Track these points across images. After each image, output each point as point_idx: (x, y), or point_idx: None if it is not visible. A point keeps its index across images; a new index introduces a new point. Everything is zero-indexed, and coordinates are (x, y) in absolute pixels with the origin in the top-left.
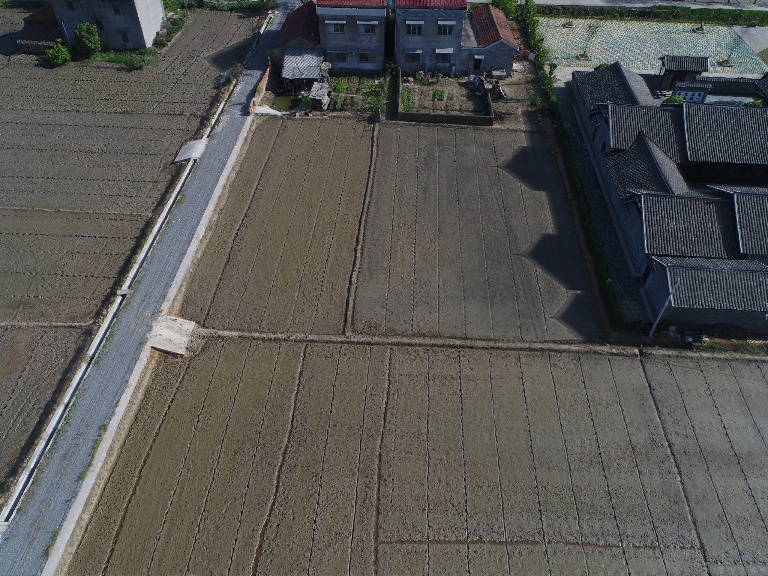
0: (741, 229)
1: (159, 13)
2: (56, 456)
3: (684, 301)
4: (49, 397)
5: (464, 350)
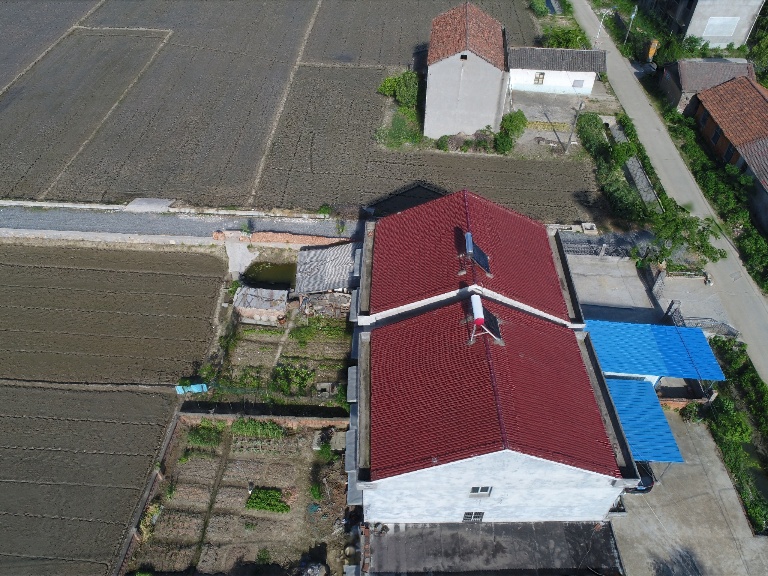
0: None
1: (485, 118)
2: None
3: None
4: None
5: None
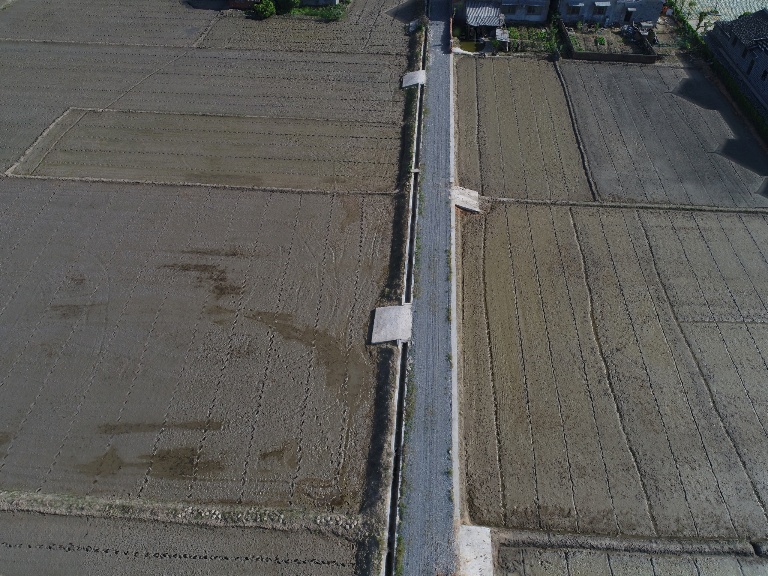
0: None
1: None
2: (423, 267)
3: None
4: (391, 236)
5: (695, 212)
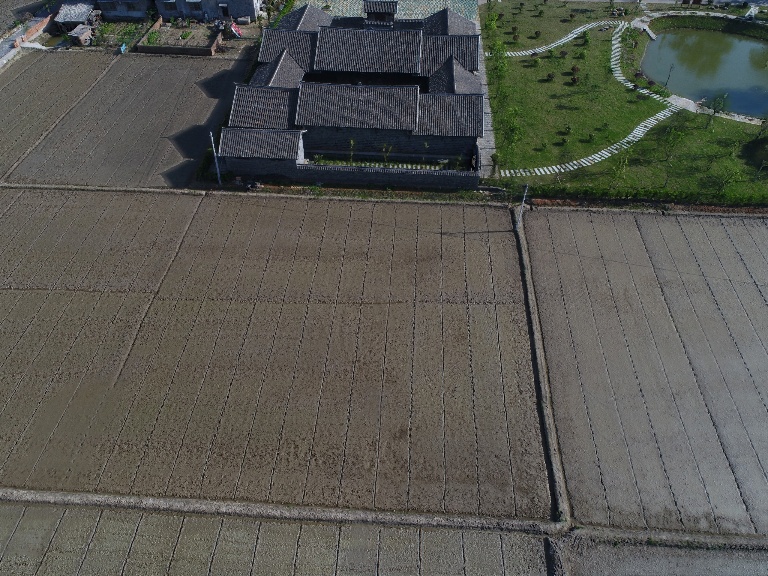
0: (299, 108)
1: None
2: None
3: (228, 152)
4: None
5: (77, 192)
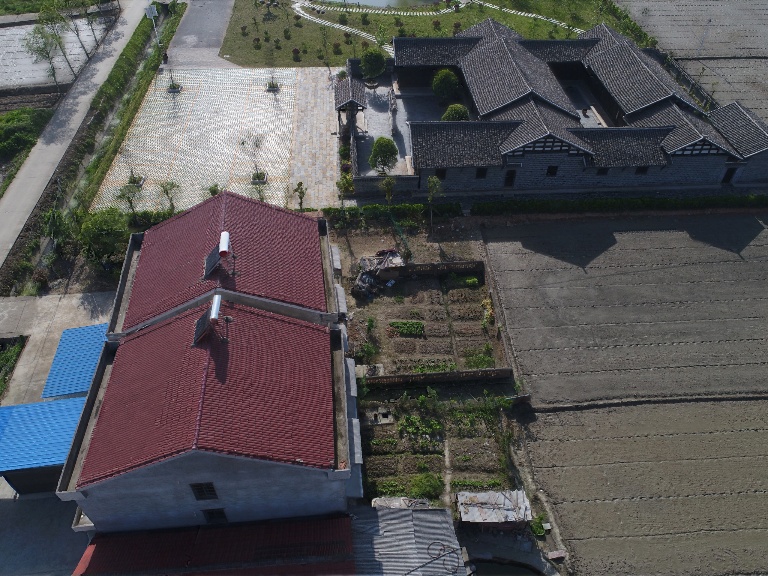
0: None
1: None
2: None
3: None
4: None
5: None
